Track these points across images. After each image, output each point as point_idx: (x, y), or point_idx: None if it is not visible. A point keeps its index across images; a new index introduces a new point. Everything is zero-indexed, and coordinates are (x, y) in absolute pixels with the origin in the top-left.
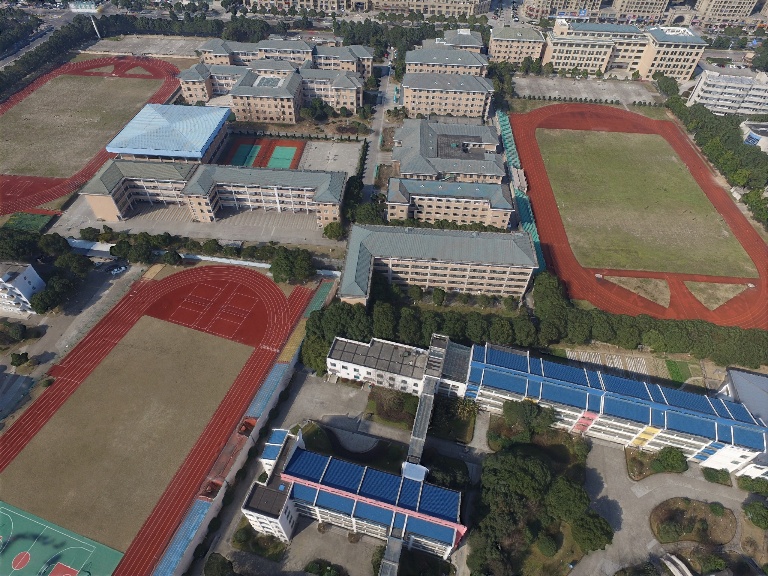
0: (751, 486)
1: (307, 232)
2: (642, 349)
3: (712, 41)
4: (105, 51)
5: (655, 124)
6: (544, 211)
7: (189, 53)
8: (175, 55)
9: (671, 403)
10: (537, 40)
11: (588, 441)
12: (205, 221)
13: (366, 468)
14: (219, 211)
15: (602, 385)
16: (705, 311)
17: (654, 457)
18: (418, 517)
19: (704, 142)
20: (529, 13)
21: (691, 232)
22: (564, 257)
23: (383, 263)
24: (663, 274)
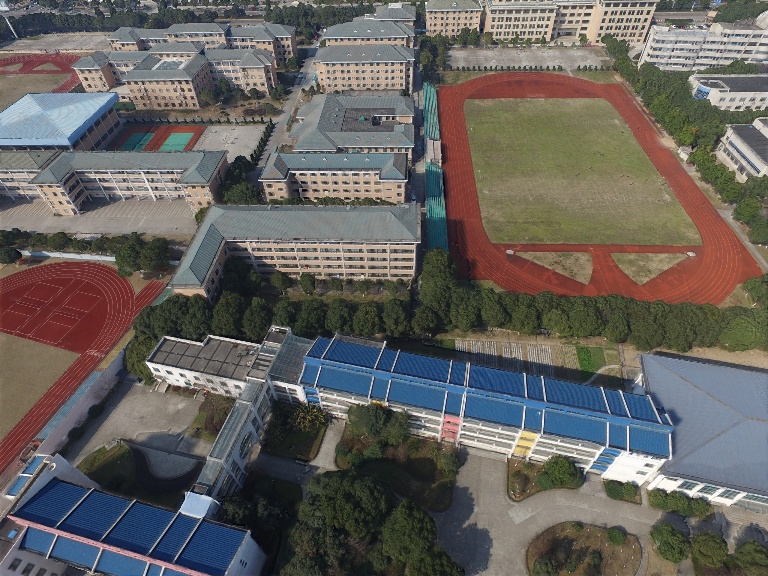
0: (664, 503)
1: (180, 220)
2: (549, 334)
3: (672, 3)
4: (17, 50)
5: (600, 88)
6: (458, 184)
7: (107, 47)
8: (90, 49)
9: (551, 399)
10: (474, 9)
11: (463, 452)
12: (68, 214)
13: (132, 503)
14: (87, 203)
15: (466, 380)
16: (632, 286)
17: (543, 469)
18: (177, 570)
19: (650, 102)
20: None
21: (626, 198)
22: (472, 233)
23: (241, 247)
24: (587, 246)
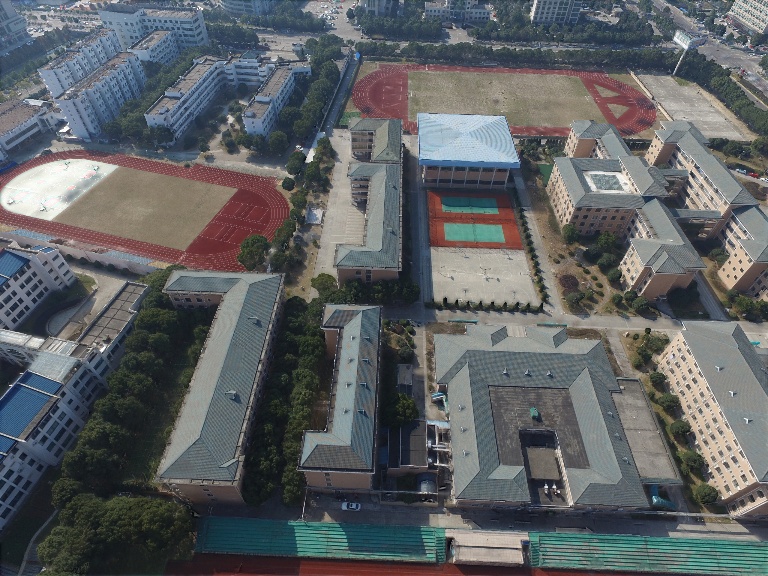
0: None
1: None
2: None
3: None
4: None
5: None
6: None
7: None
8: None
9: None
10: None
11: None
12: None
13: None
14: None
15: None
16: None
17: None
18: None
19: None
20: None
21: None
22: None
23: None
24: None
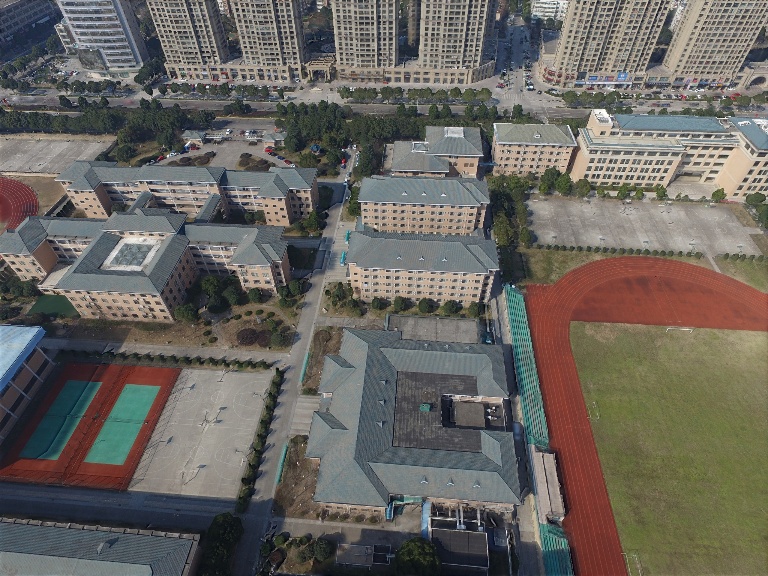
0: None
1: None
2: None
3: None
4: None
5: None
6: None
7: (65, 166)
8: (41, 173)
9: None
10: (564, 144)
11: None
12: None
13: None
14: None
15: None
16: None
17: None
18: None
19: None
20: (548, 77)
21: None
22: None
23: None
24: None
